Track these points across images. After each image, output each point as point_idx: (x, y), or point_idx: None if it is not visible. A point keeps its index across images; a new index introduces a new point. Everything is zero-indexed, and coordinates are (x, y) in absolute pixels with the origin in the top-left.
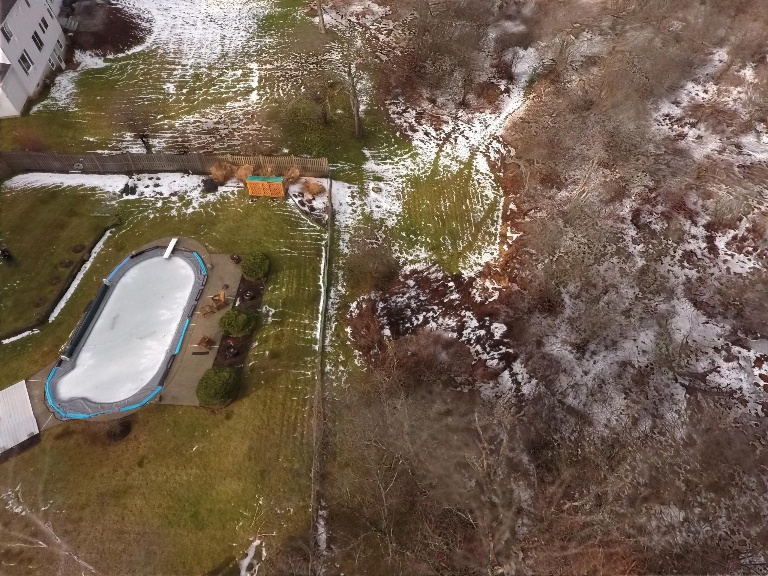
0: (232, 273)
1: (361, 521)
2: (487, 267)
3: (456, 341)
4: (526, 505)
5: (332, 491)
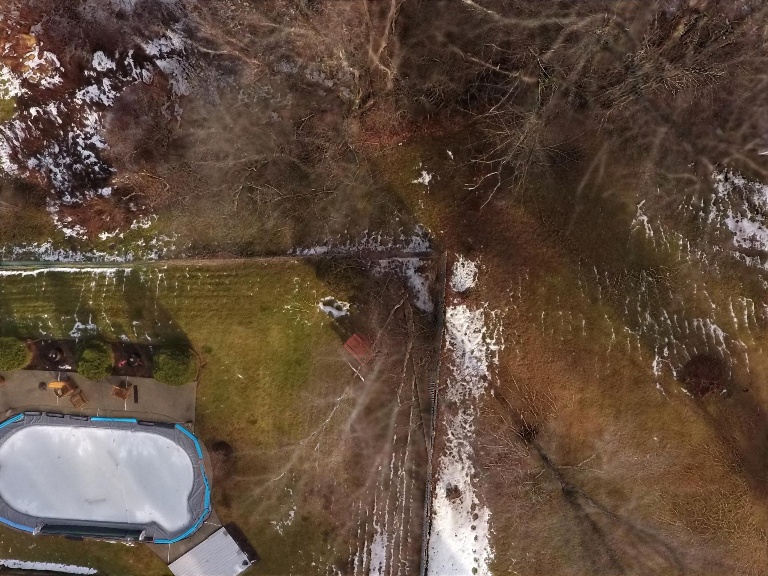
0: (20, 383)
1: (306, 217)
2: (4, 60)
3: (118, 101)
4: (295, 68)
5: (280, 243)
